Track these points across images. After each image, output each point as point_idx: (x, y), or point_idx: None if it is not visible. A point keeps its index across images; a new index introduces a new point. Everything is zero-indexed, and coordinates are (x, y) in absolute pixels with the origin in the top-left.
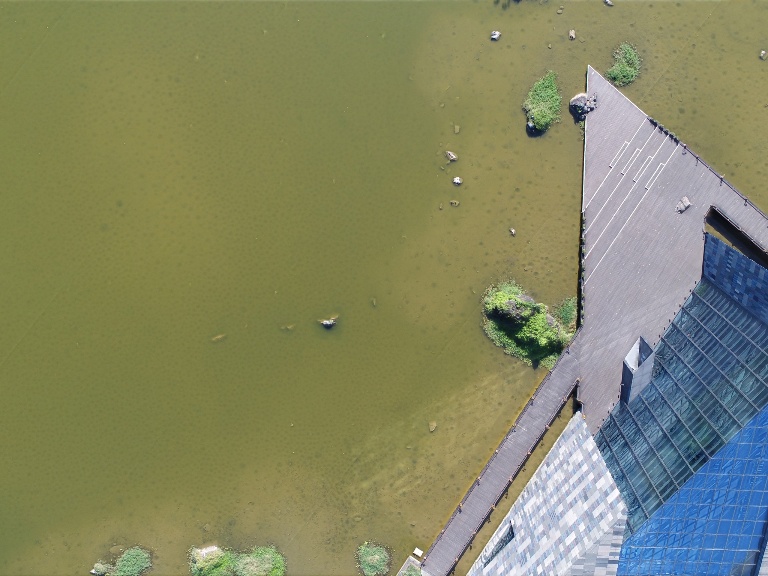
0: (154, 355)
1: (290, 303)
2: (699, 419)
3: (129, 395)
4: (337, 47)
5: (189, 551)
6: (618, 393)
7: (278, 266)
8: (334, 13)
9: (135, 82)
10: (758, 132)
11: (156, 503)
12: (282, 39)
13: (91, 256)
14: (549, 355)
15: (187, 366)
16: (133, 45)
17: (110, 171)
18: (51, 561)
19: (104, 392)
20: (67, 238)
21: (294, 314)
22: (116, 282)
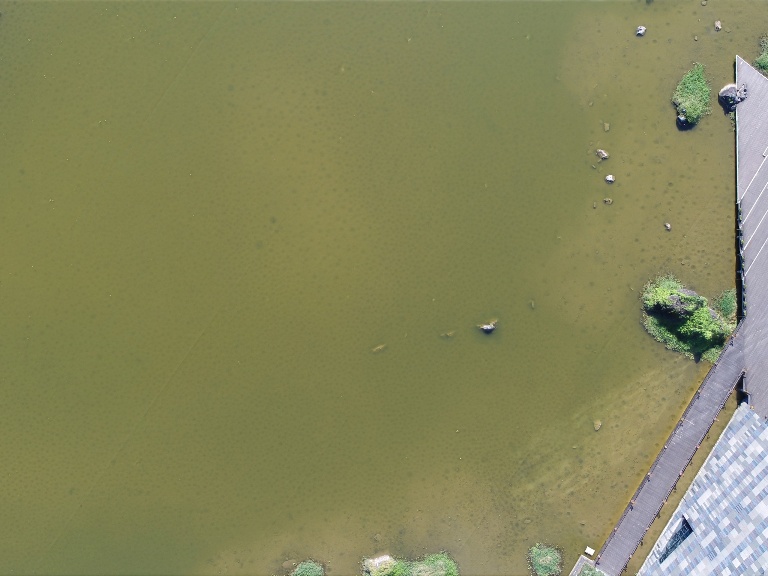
0: (316, 369)
1: (448, 310)
2: None
3: (293, 410)
4: (482, 51)
5: (361, 562)
6: None
7: (435, 274)
8: (477, 17)
9: (282, 98)
10: None
11: (326, 516)
12: (426, 46)
13: (248, 274)
14: (711, 348)
15: (349, 378)
16: (278, 61)
17: (262, 188)
18: None
19: (268, 408)
20: (223, 257)
21: (453, 321)
22: (274, 298)
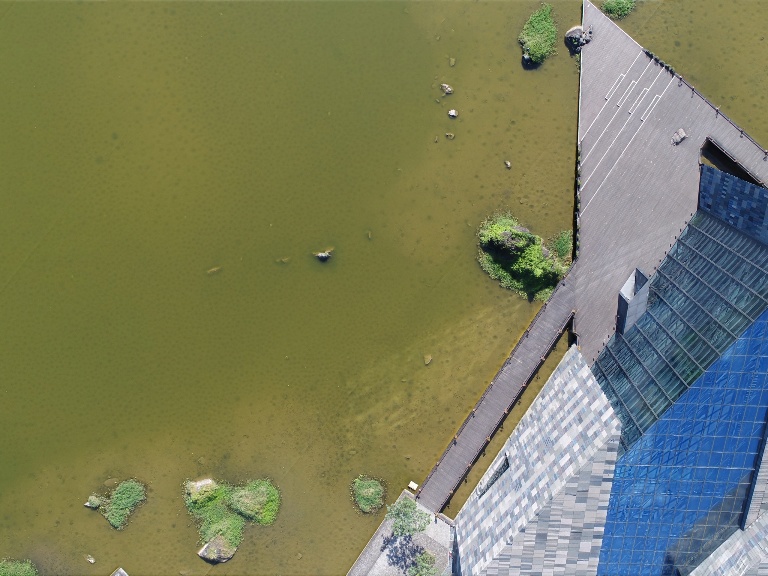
0: (149, 288)
1: (285, 236)
2: (694, 338)
3: (124, 328)
4: None
5: (184, 484)
6: (614, 325)
7: (273, 199)
8: None
9: (131, 15)
10: (754, 65)
11: (151, 436)
12: None
13: (86, 189)
14: (544, 288)
15: (182, 299)
16: None
17: (105, 104)
18: (45, 494)
19: (99, 325)
20: (62, 170)
21: (289, 247)
22: (111, 215)
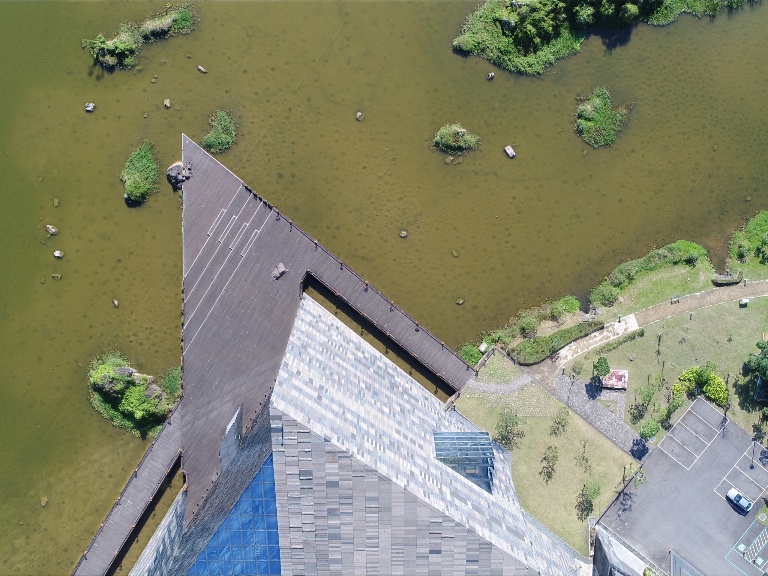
0: None
1: None
2: None
3: None
4: None
5: None
6: None
7: None
8: None
9: None
10: (358, 194)
11: None
12: None
13: None
14: (157, 425)
15: None
16: None
17: None
18: None
19: None
20: None
21: None
22: None
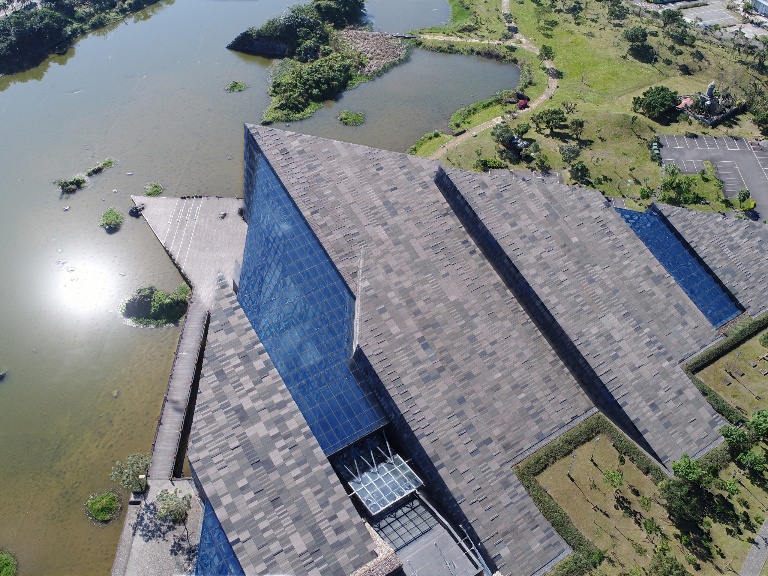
0: None
1: None
2: None
3: None
4: None
5: None
6: None
7: None
8: None
9: None
10: None
11: None
12: None
13: None
14: (183, 315)
15: None
16: None
17: None
18: None
19: None
20: None
21: None
22: None
